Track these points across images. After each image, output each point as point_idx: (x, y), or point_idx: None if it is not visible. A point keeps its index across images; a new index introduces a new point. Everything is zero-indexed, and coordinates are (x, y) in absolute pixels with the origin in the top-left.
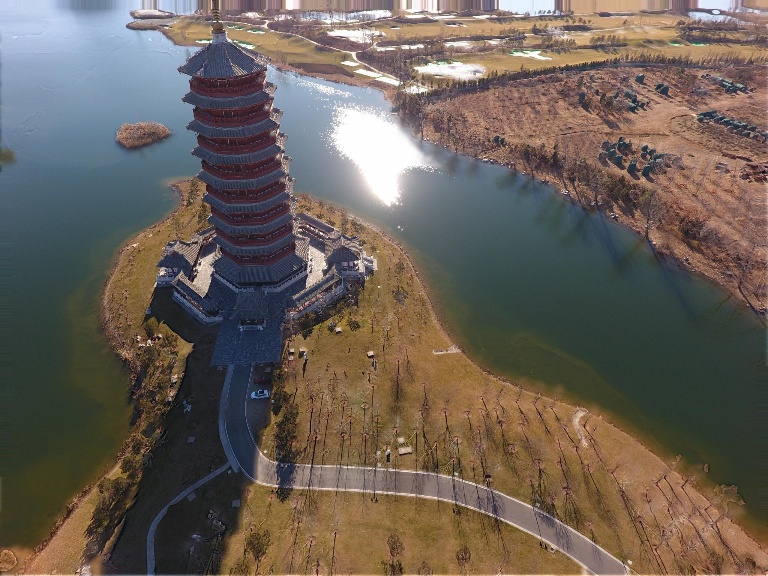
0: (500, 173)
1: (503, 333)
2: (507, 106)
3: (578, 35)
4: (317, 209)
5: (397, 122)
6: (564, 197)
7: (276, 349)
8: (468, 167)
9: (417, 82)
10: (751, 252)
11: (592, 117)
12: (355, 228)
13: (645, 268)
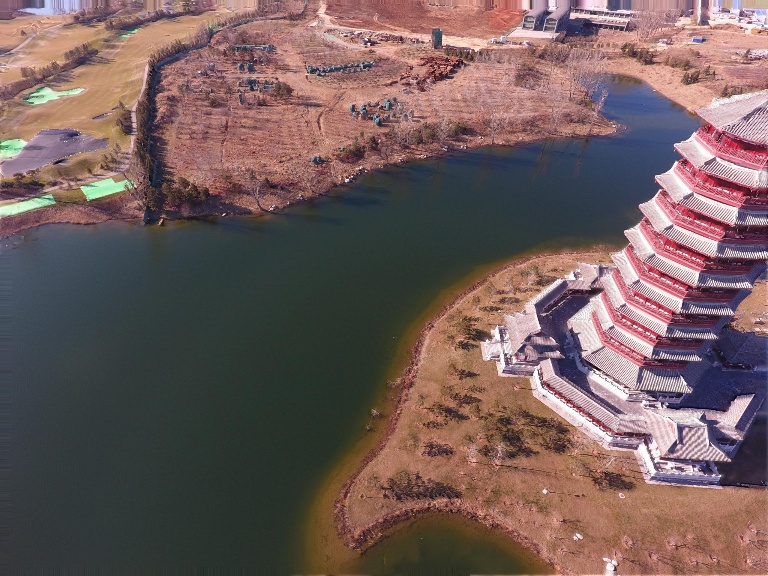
0: (366, 181)
1: (631, 226)
2: (226, 138)
3: (16, 59)
4: (466, 314)
5: (192, 225)
6: (431, 159)
7: (762, 341)
8: (357, 194)
9: (75, 181)
10: (523, 116)
11: (290, 107)
12: (537, 273)
13: (530, 156)
